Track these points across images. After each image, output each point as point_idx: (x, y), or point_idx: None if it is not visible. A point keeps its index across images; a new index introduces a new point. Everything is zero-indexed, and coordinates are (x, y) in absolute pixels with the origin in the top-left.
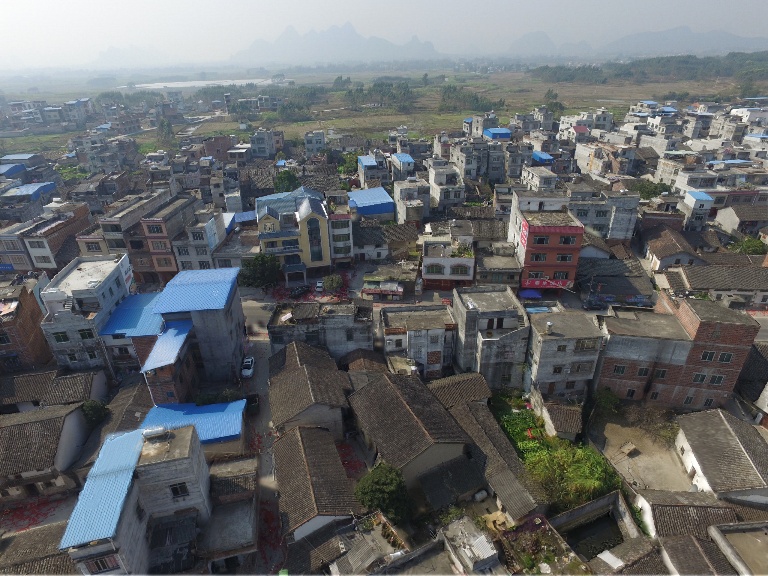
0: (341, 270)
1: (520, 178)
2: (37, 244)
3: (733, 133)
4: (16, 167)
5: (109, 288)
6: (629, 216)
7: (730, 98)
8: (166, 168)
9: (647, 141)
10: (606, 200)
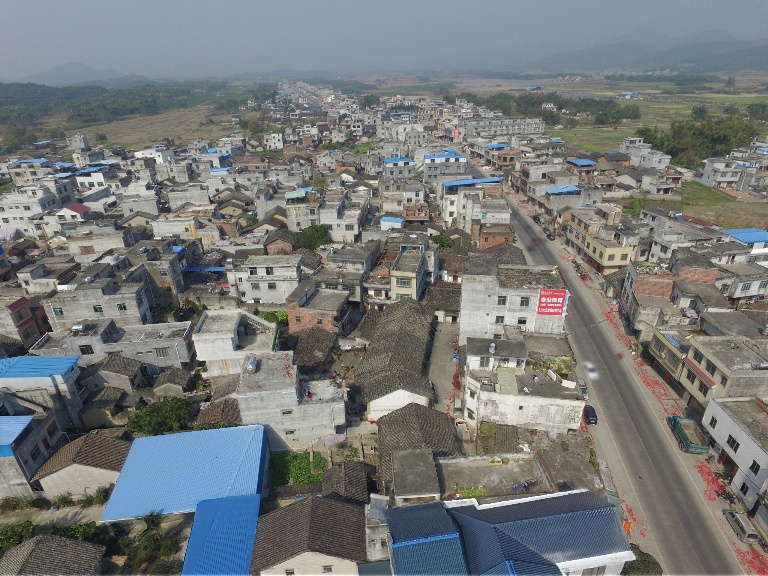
0: None
1: (195, 287)
2: None
3: (187, 173)
4: None
5: None
6: (437, 254)
7: (19, 146)
8: None
9: (179, 198)
10: (422, 249)
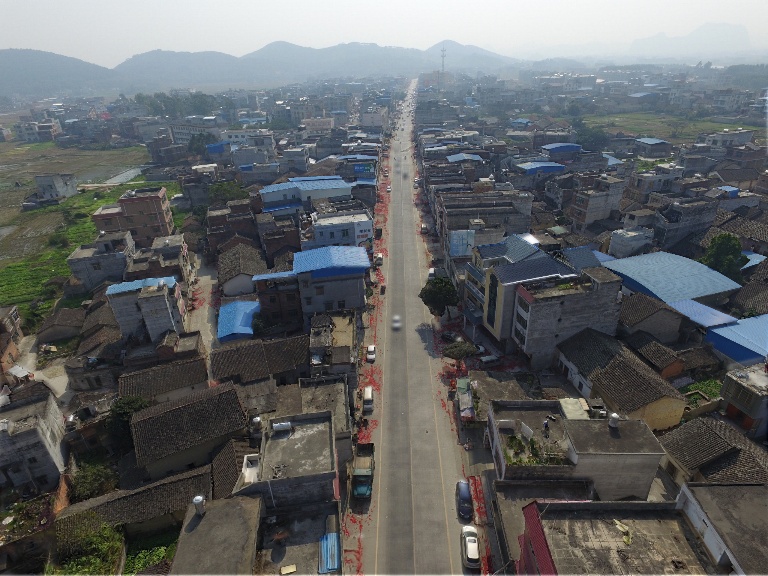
0: (523, 360)
1: None
2: None
3: None
4: (568, 147)
5: (331, 232)
6: None
7: None
8: (613, 181)
9: None
10: None
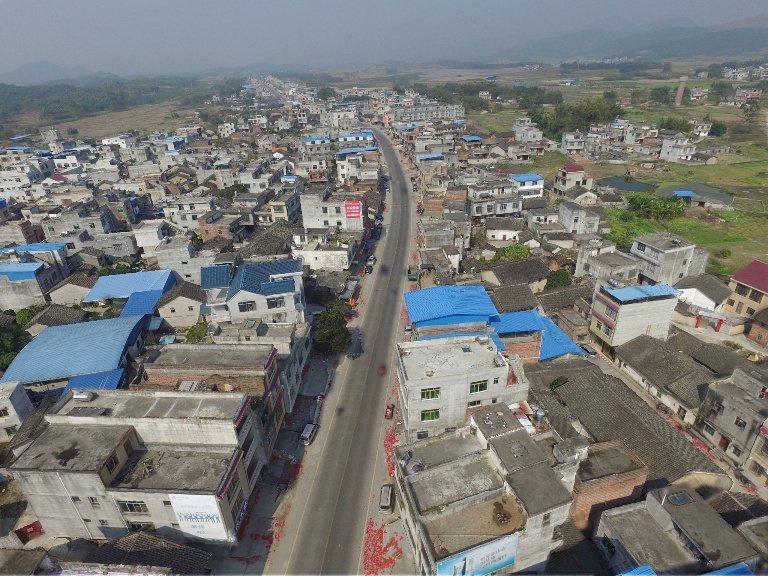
0: None
1: None
2: None
3: (146, 154)
4: None
5: None
6: None
7: None
8: None
9: (136, 170)
10: (296, 190)
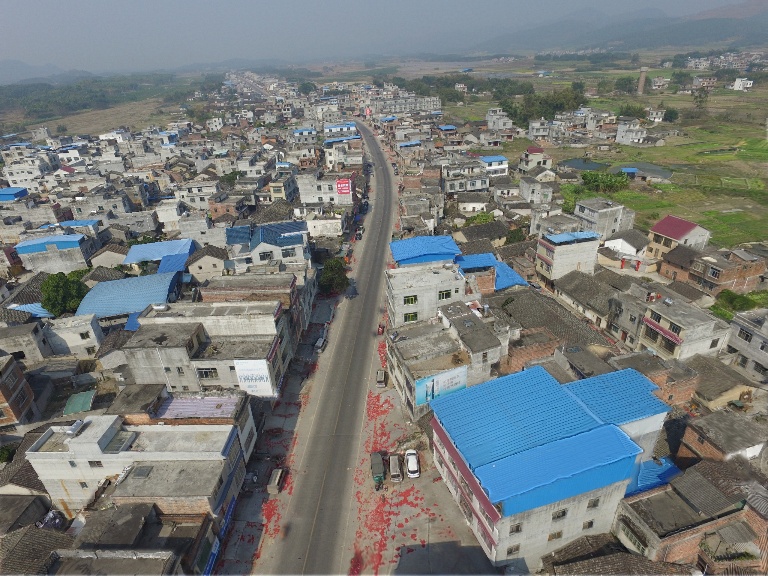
0: None
1: (156, 204)
2: (244, 419)
3: (143, 148)
4: None
5: None
6: None
7: None
8: None
9: (140, 161)
10: (291, 173)
